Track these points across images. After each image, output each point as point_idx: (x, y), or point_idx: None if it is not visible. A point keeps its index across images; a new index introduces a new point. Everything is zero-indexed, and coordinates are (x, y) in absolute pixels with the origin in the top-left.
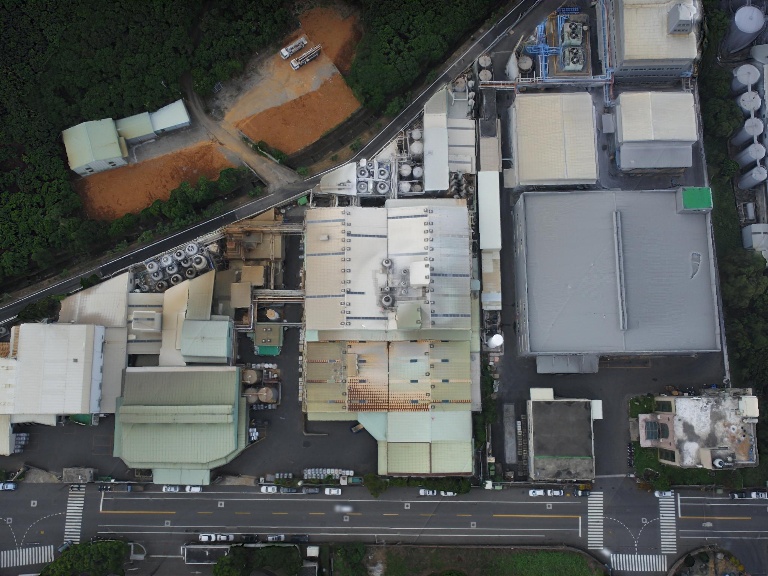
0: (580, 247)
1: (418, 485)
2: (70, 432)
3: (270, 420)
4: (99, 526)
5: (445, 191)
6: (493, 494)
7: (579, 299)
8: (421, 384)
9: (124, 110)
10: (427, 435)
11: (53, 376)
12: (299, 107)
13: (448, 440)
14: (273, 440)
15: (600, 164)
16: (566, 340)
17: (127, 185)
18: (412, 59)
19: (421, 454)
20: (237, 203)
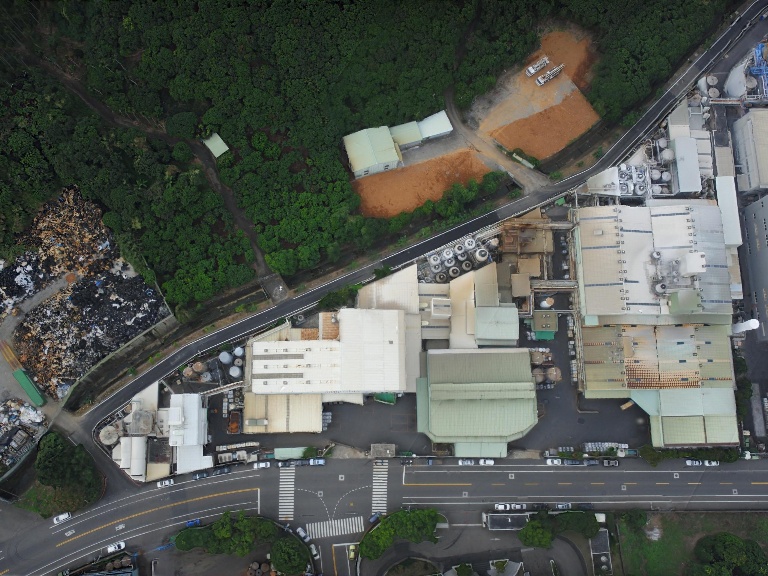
0: None
1: (686, 456)
2: (369, 411)
3: (547, 399)
4: (403, 498)
5: None
6: (749, 464)
7: None
8: (689, 364)
9: (397, 119)
10: (699, 409)
11: (372, 356)
12: (545, 119)
13: (717, 413)
14: (551, 417)
15: None
16: None
17: (397, 187)
18: (646, 78)
19: (695, 426)
20: (498, 204)
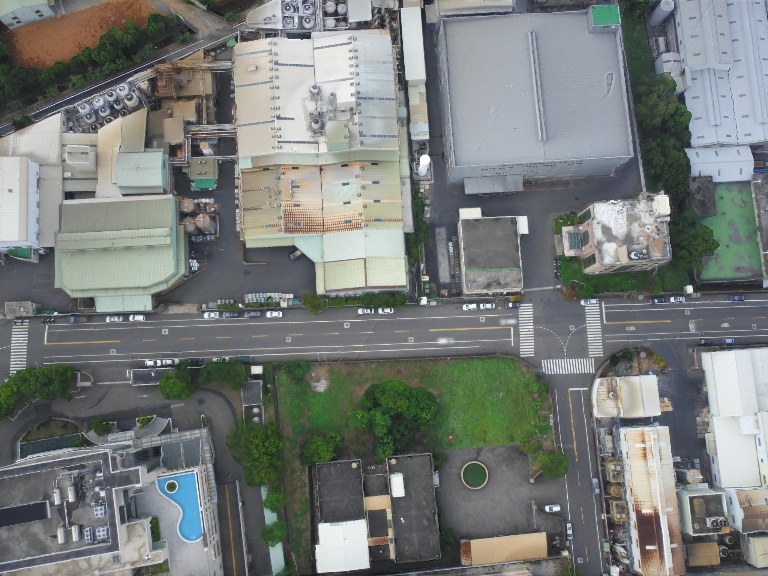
0: (501, 75)
1: (356, 304)
2: (10, 270)
3: (210, 252)
4: (44, 357)
5: (369, 23)
6: (429, 311)
7: (502, 122)
8: (354, 205)
9: None
10: (361, 251)
11: None
12: None
13: (382, 256)
14: (213, 270)
15: (518, 1)
16: (490, 159)
17: (56, 36)
18: None
19: (356, 270)
20: (167, 49)
